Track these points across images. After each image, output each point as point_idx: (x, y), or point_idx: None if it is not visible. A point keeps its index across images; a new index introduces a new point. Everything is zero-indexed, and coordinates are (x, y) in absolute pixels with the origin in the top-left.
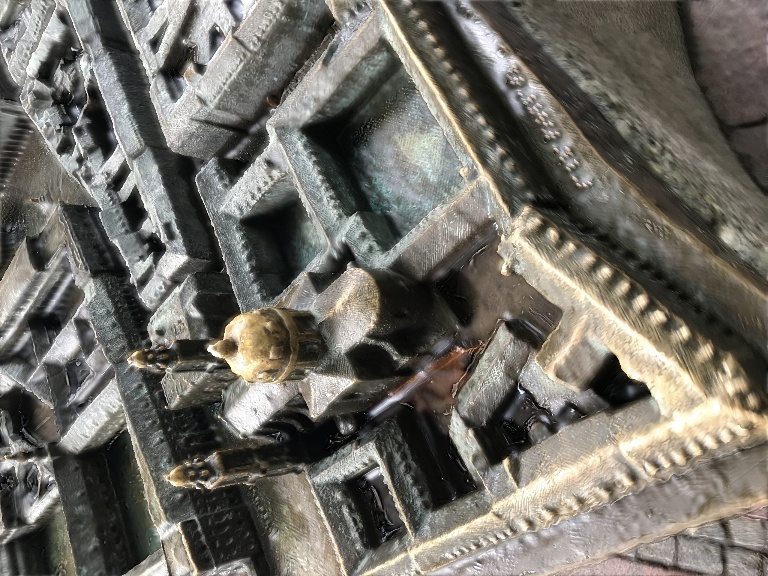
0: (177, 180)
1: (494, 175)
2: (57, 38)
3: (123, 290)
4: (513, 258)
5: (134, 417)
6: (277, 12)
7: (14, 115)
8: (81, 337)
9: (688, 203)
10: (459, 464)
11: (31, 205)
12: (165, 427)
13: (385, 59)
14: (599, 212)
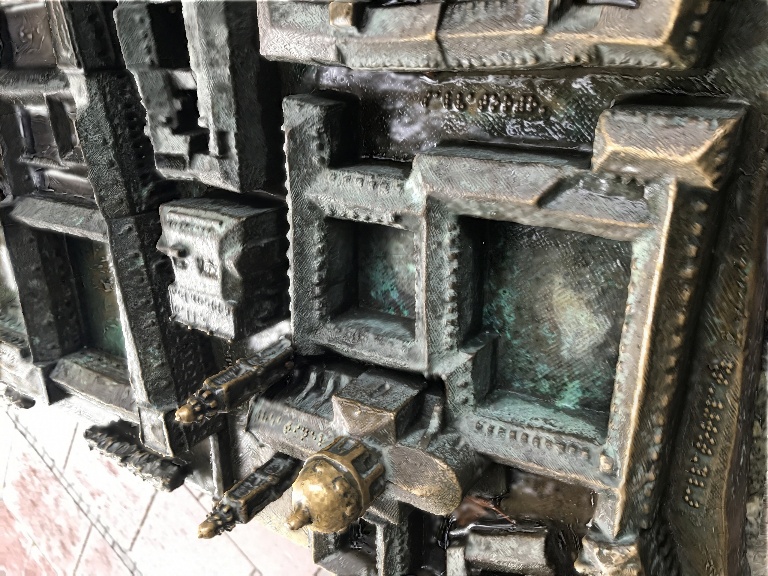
0: (248, 53)
1: (629, 497)
2: None
3: (124, 103)
4: (593, 573)
5: (126, 291)
6: (521, 64)
7: None
8: (55, 124)
9: (750, 473)
10: (438, 542)
11: None
12: (158, 308)
13: None
14: (683, 525)
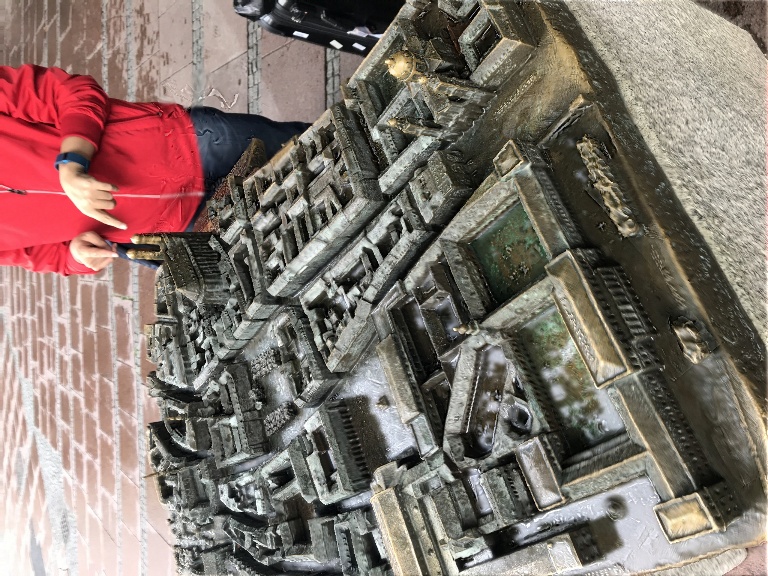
0: None
1: None
2: (316, 317)
3: None
4: None
5: None
6: (344, 131)
7: (336, 410)
8: None
9: None
10: None
11: (383, 434)
12: None
13: (372, 87)
14: None
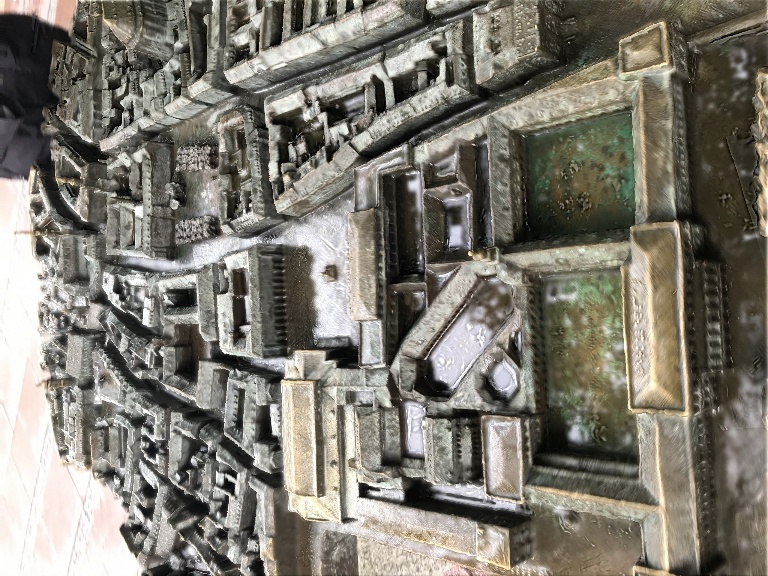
0: None
1: None
2: (279, 137)
3: None
4: None
5: None
6: None
7: (269, 256)
8: None
9: None
10: None
11: (318, 306)
12: None
13: None
14: None
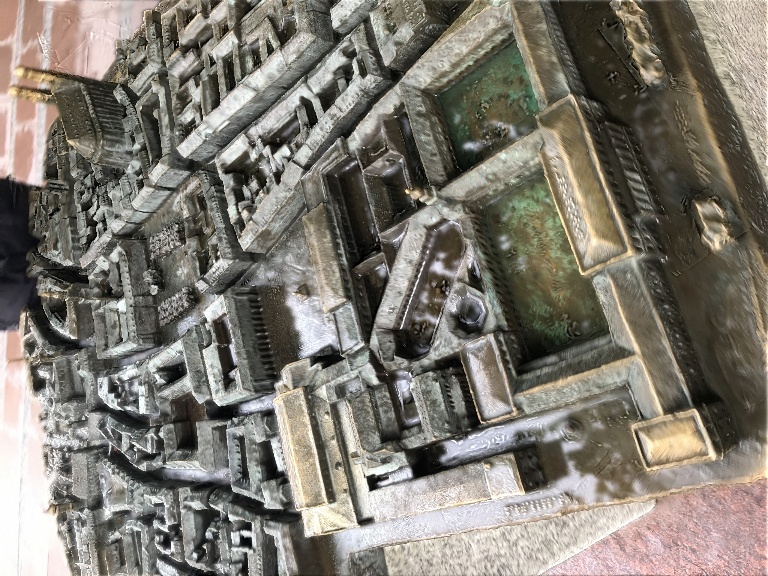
0: None
1: None
2: (233, 184)
3: None
4: None
5: None
6: None
7: (244, 297)
8: None
9: None
10: None
11: (298, 329)
12: None
13: None
14: None
